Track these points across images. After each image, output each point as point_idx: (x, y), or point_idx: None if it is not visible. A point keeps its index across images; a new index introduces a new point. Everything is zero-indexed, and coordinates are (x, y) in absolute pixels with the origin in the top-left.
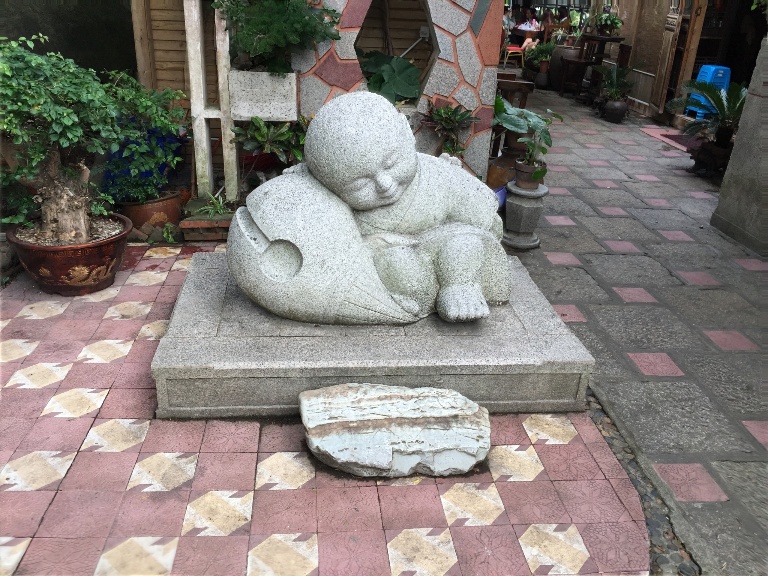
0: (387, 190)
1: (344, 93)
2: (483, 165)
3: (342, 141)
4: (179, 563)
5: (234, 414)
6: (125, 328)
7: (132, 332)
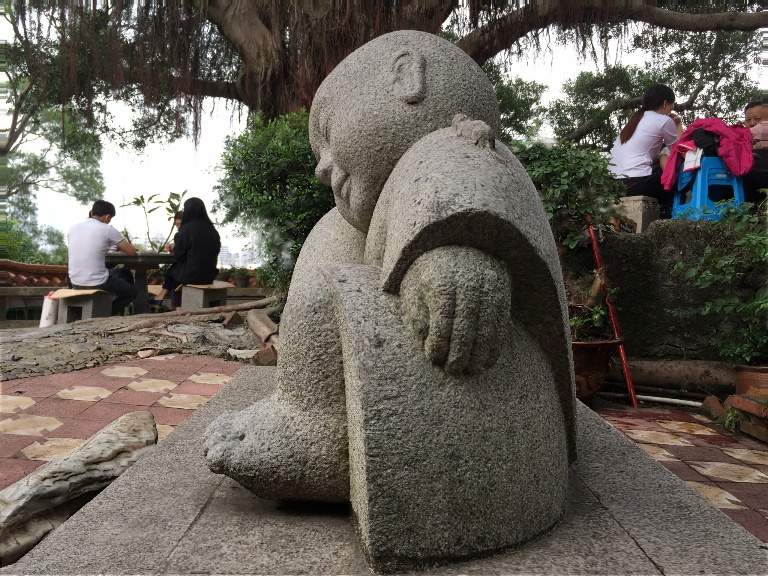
0: (326, 180)
1: None
2: None
3: None
4: (9, 435)
5: None
6: None
7: None
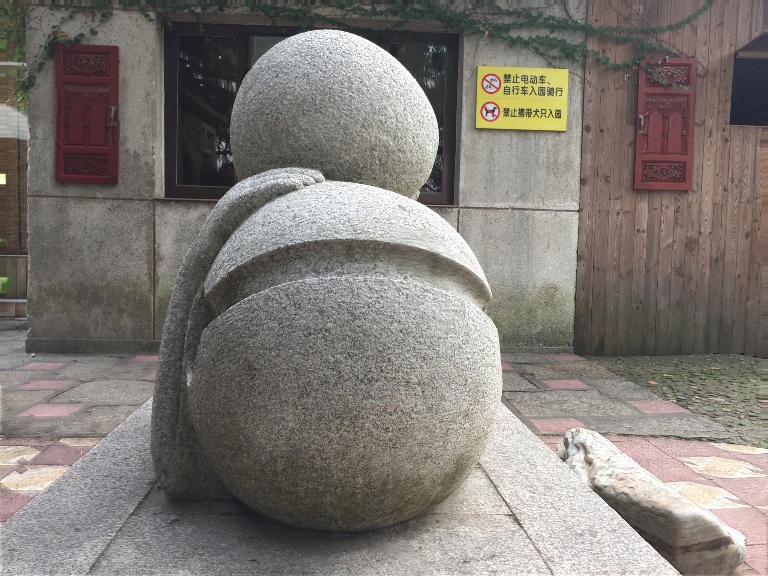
0: None
1: None
2: None
3: None
4: None
5: None
6: None
7: None
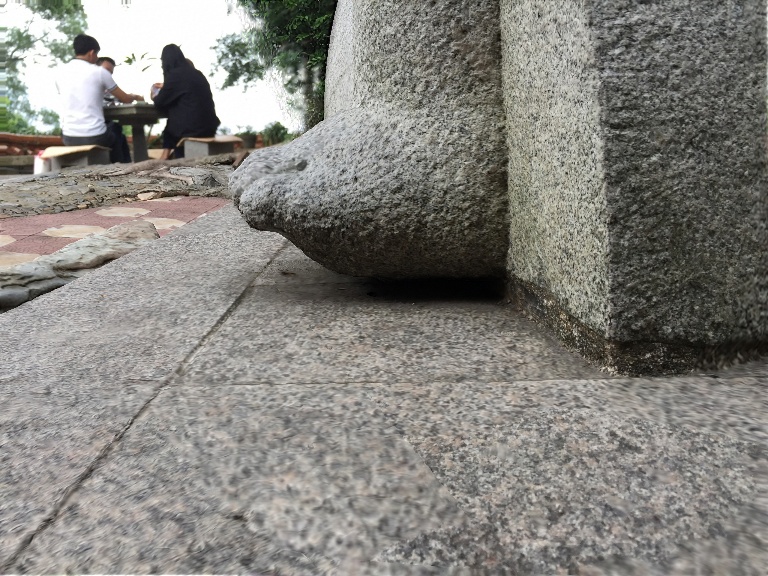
0: None
1: None
2: None
3: None
4: None
5: None
6: None
7: None
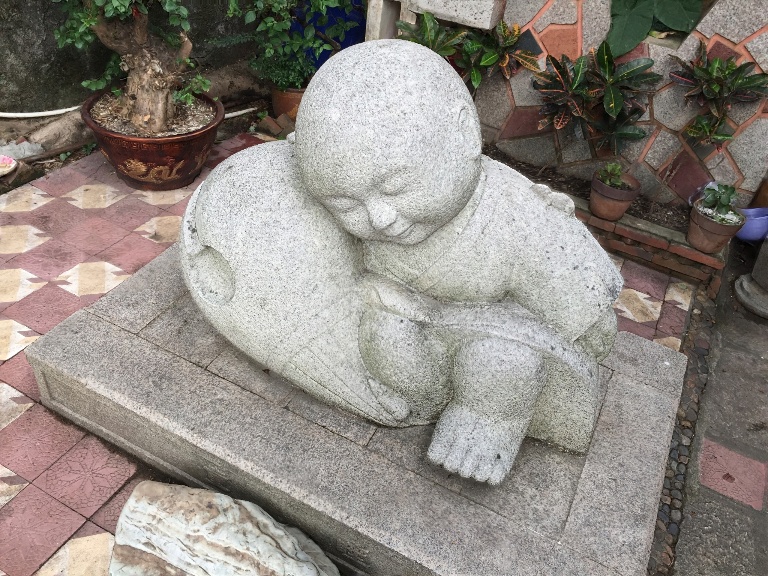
0: None
1: (571, 2)
2: (760, 165)
3: (317, 128)
4: None
5: (116, 443)
6: (140, 253)
7: (141, 262)
